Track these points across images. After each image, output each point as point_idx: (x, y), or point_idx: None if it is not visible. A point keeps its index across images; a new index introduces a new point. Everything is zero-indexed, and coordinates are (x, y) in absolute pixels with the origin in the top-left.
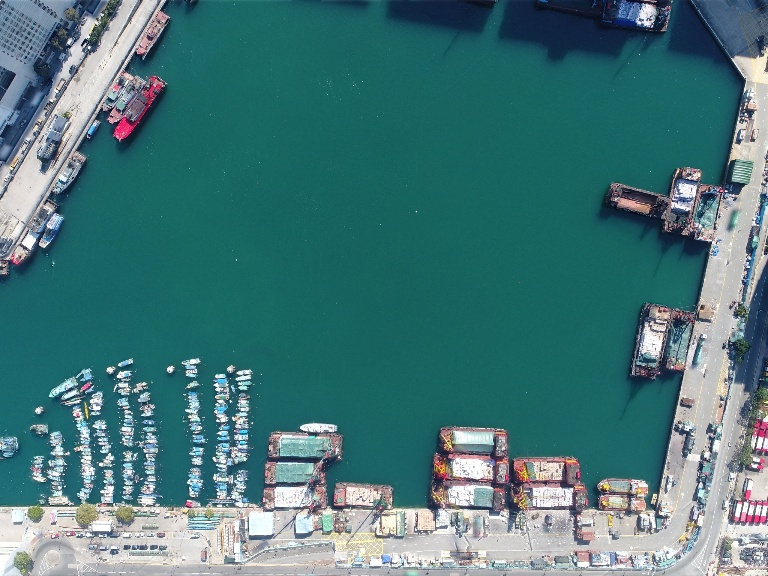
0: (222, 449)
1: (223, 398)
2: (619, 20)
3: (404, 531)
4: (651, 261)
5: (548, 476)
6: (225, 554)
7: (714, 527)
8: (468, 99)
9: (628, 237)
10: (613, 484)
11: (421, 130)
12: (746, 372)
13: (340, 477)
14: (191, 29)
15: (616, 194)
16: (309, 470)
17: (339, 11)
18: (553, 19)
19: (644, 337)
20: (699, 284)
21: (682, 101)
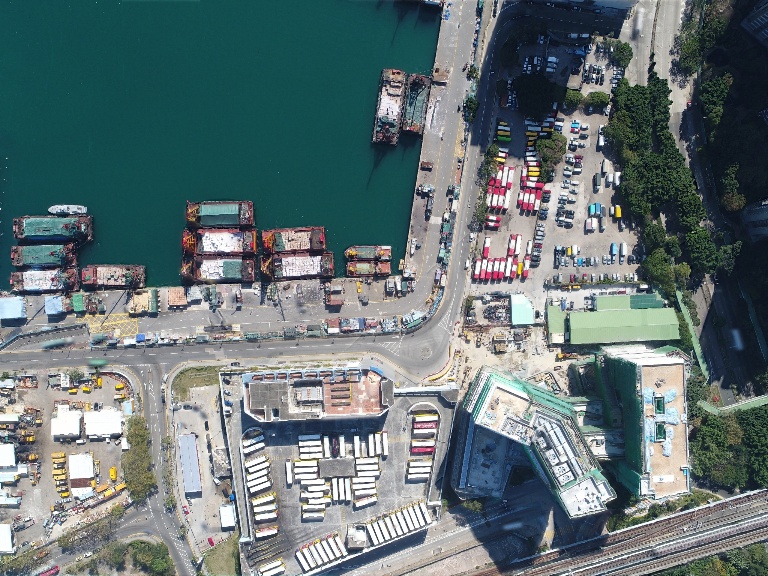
0: None
1: None
2: None
3: (156, 307)
4: (388, 29)
5: (297, 246)
6: None
7: (458, 288)
8: None
9: (364, 5)
10: (360, 250)
11: None
12: (481, 133)
13: (92, 259)
14: None
15: None
16: None
17: None
18: None
19: (381, 101)
20: (435, 50)
21: None
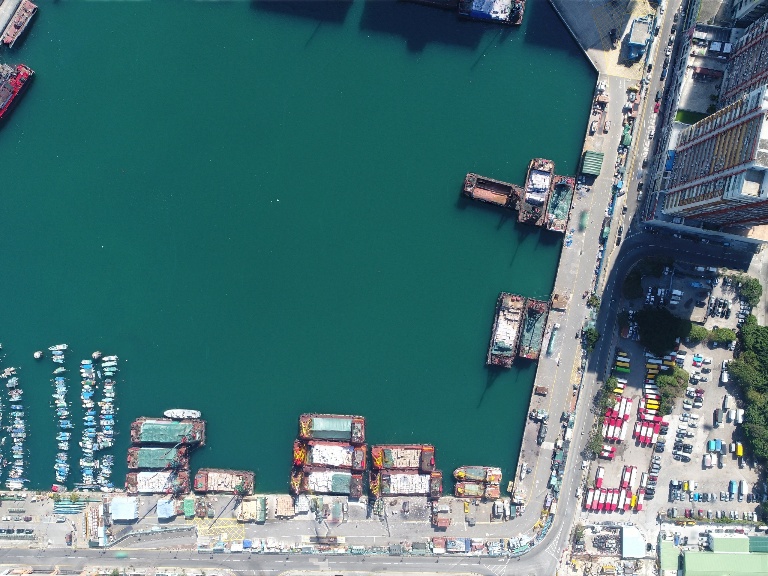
0: (88, 434)
1: (89, 383)
2: (474, 12)
3: (264, 516)
4: (508, 251)
5: (406, 463)
6: (90, 538)
7: (568, 515)
8: (329, 89)
9: (485, 227)
10: (469, 471)
11: (283, 120)
12: (599, 361)
13: (203, 463)
14: (59, 18)
15: (469, 184)
16: (171, 455)
17: (203, 2)
18: (412, 11)
19: (498, 326)
20: (554, 274)
21: (537, 93)
